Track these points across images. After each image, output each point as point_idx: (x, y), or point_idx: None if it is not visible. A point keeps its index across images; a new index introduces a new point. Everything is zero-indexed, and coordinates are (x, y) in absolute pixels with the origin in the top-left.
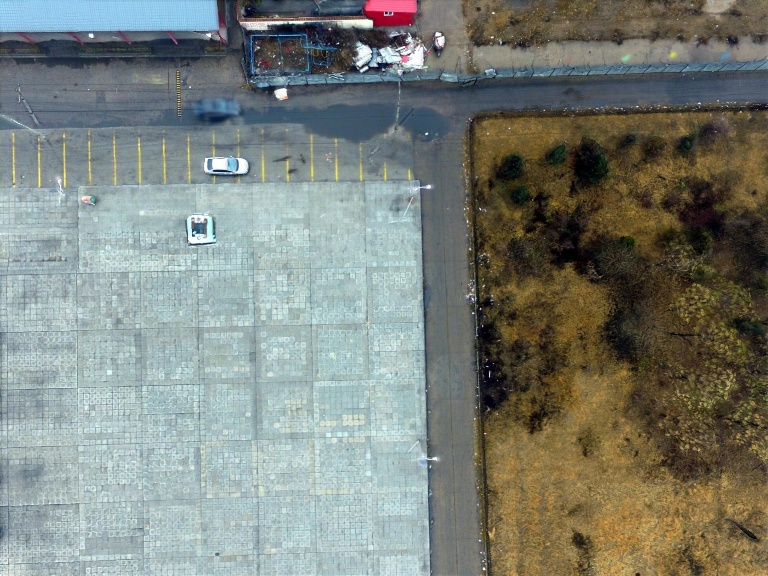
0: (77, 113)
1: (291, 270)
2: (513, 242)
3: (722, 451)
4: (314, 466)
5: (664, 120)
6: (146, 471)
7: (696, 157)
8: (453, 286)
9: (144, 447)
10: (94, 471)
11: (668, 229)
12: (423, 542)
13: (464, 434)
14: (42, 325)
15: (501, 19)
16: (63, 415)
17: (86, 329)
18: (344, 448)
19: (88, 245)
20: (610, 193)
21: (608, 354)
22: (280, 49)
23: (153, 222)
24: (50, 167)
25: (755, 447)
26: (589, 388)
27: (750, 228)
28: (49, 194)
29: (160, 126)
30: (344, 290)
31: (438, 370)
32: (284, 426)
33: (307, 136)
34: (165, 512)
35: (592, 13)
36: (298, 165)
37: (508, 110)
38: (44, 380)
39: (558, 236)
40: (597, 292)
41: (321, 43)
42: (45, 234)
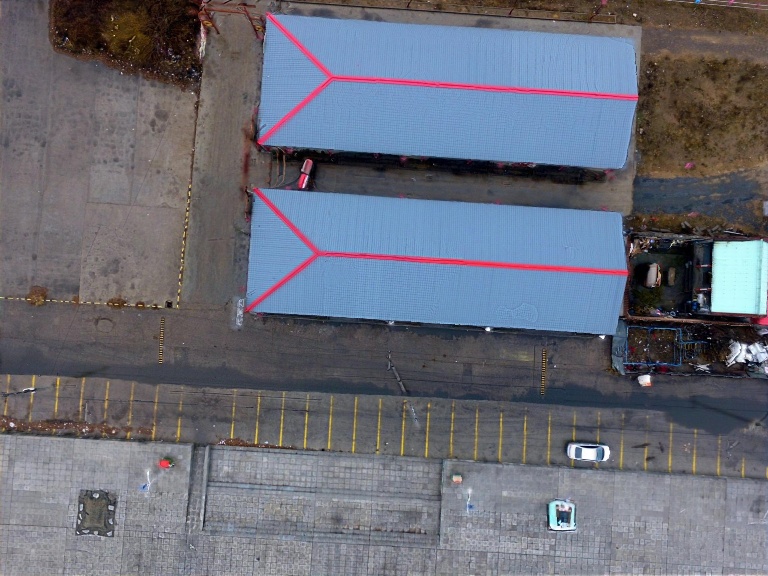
0: (443, 383)
1: (648, 563)
2: None
3: None
4: None
5: None
6: None
7: None
8: None
9: None
10: None
11: None
12: None
13: None
14: None
15: None
16: None
17: None
18: None
19: (450, 521)
20: None
21: None
22: (648, 337)
23: (515, 503)
24: (413, 435)
25: None
26: None
27: None
28: (412, 464)
29: (522, 402)
30: None
31: None
32: None
33: (667, 424)
34: None
35: None
36: (656, 453)
37: None
38: None
39: None
40: None
41: (688, 333)
42: (407, 505)
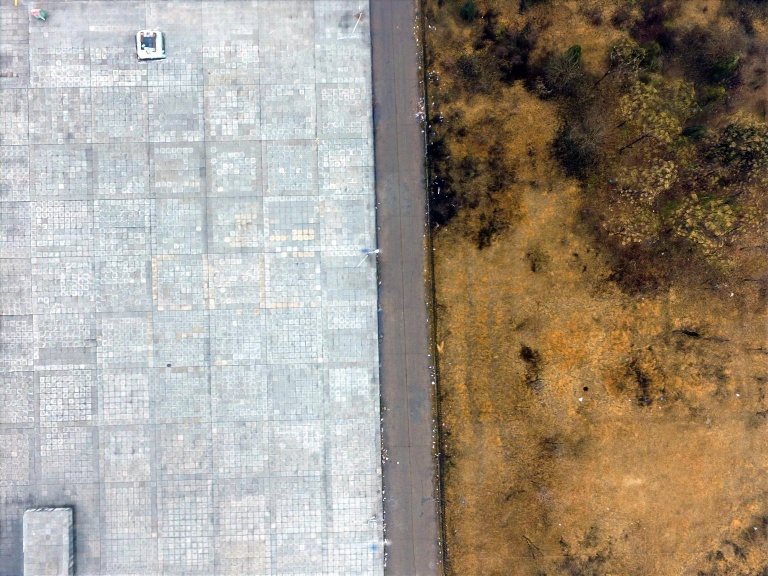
0: None
1: (240, 86)
2: (462, 59)
3: (670, 266)
4: (264, 280)
5: None
6: (98, 283)
7: None
8: (403, 104)
9: (96, 260)
10: (47, 283)
11: None
12: (372, 355)
13: (413, 251)
14: None
15: None
16: (16, 228)
17: (38, 143)
18: (294, 262)
19: (39, 60)
20: (560, 10)
21: (557, 170)
22: None
23: (103, 38)
24: None
25: (695, 234)
26: (538, 204)
27: (700, 41)
28: (0, 11)
29: None
30: (293, 106)
31: (388, 188)
32: (234, 240)
33: None
34: (117, 324)
35: None
36: None
37: None
38: None
39: (507, 51)
40: (546, 109)
41: None
42: None
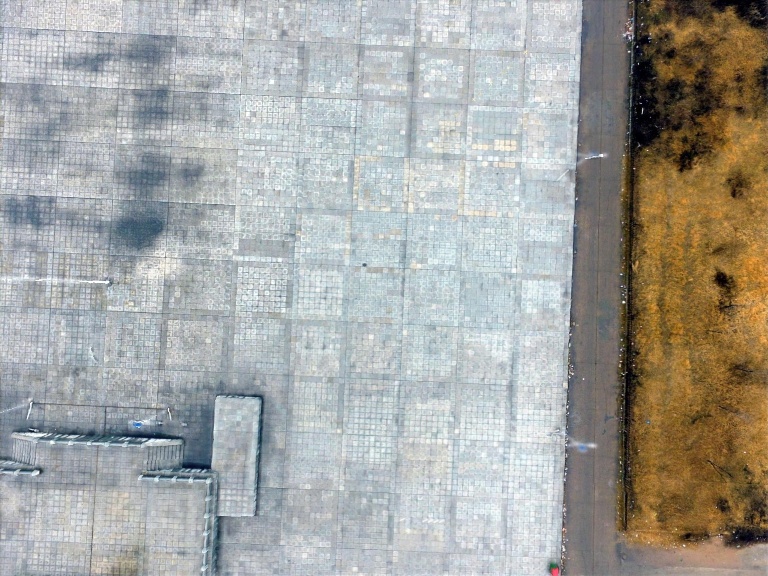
0: None
1: None
2: None
3: None
4: (464, 187)
5: None
6: (301, 179)
7: None
8: (611, 24)
9: (300, 156)
10: (251, 175)
11: None
12: (566, 269)
13: (612, 169)
14: (210, 31)
15: None
16: (225, 119)
17: (252, 38)
18: (494, 172)
19: None
20: None
21: (763, 98)
22: None
23: None
24: None
25: None
26: (742, 131)
27: None
28: None
29: None
30: (504, 18)
31: (590, 105)
32: (437, 146)
33: None
34: (317, 220)
35: None
36: None
37: None
38: (209, 84)
39: None
40: (756, 36)
41: None
42: None
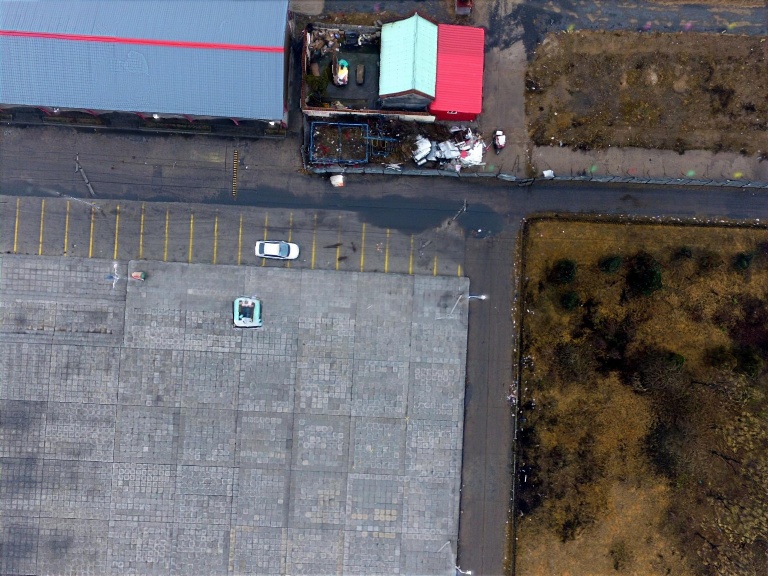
0: (133, 186)
1: (334, 359)
2: (559, 347)
3: None
4: (342, 558)
5: (721, 235)
6: (175, 551)
7: (751, 275)
8: (495, 386)
9: (174, 526)
10: (123, 547)
11: (717, 346)
12: None
13: (495, 537)
14: (83, 397)
15: (563, 120)
16: (97, 488)
17: (126, 404)
18: (374, 543)
19: (134, 320)
20: (661, 305)
21: (647, 468)
22: (339, 136)
23: (200, 301)
24: (102, 238)
25: None
26: (625, 501)
27: None
28: (99, 265)
29: (214, 204)
30: (386, 383)
31: (474, 470)
32: (315, 516)
33: (359, 224)
34: None
35: (655, 121)
36: (348, 253)
37: (563, 213)
38: (80, 452)
39: (605, 345)
40: (640, 404)
41: (381, 132)
42: (92, 305)
